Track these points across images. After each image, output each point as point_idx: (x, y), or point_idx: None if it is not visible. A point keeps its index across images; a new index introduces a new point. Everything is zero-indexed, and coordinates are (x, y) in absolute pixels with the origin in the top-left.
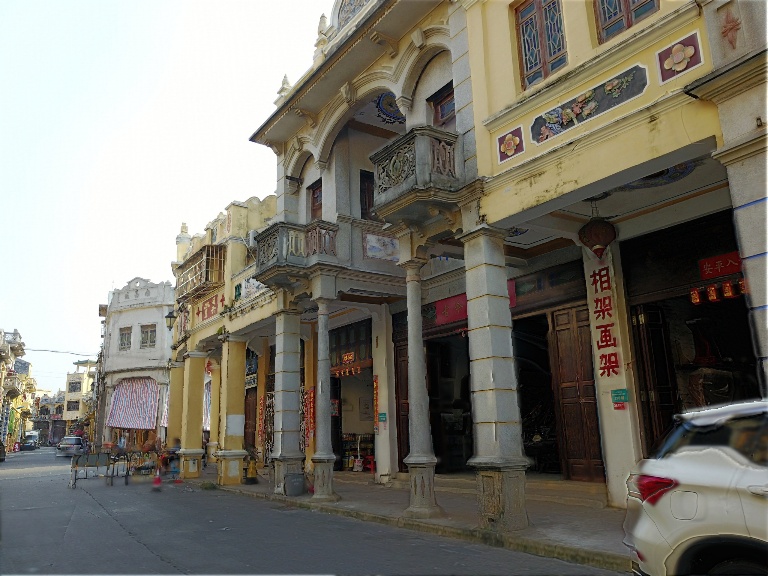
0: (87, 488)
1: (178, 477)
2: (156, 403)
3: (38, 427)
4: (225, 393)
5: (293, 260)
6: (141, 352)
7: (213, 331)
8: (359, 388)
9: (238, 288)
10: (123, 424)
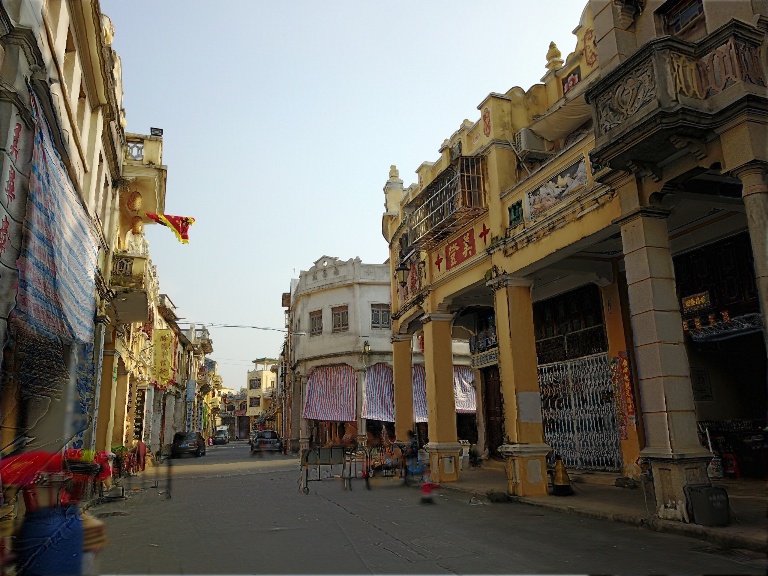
0: (323, 493)
1: (429, 480)
2: (354, 392)
3: (225, 423)
4: (509, 361)
5: (688, 102)
6: (334, 337)
7: (470, 279)
8: (690, 353)
9: (514, 209)
10: (320, 416)
